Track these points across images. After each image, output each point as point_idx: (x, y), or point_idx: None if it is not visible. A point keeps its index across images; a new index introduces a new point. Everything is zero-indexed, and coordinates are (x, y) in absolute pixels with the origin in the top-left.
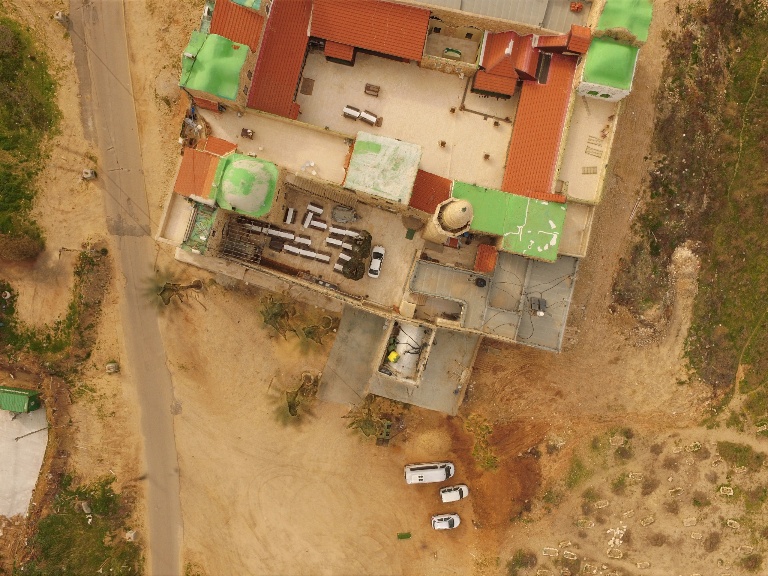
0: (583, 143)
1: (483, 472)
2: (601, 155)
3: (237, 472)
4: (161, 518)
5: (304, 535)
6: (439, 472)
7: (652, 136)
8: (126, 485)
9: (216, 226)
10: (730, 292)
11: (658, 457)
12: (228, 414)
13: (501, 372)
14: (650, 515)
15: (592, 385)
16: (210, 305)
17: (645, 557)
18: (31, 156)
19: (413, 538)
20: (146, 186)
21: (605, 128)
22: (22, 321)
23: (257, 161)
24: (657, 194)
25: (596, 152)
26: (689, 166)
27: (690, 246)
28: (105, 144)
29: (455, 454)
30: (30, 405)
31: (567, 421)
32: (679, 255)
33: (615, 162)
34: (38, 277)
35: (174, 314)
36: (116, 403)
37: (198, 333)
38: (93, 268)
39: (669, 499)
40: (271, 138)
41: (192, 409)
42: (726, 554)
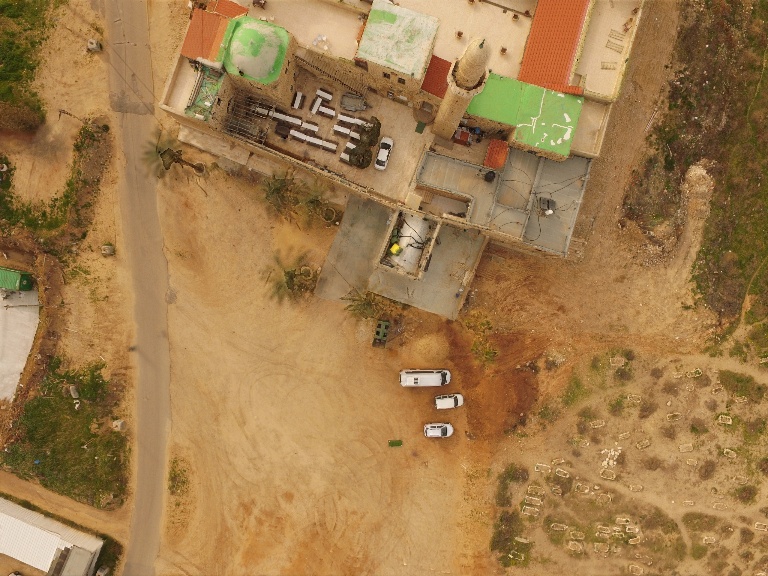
0: (604, 37)
1: (480, 381)
2: (622, 50)
3: (229, 367)
4: (150, 410)
5: (294, 436)
6: (435, 376)
7: (674, 44)
8: (116, 372)
9: (222, 94)
10: (742, 218)
11: (658, 381)
12: (223, 307)
13: (504, 282)
14: (646, 438)
15: (596, 302)
16: (211, 191)
17: (638, 480)
18: (35, 25)
19: (404, 446)
20: (152, 62)
21: (628, 21)
22: (18, 196)
23: (268, 25)
24: (675, 105)
25: (617, 47)
26: (710, 78)
27: (705, 165)
28: (112, 16)
29: (452, 362)
30: (22, 283)
31: (568, 338)
32: (693, 173)
33: (635, 69)
34: (37, 151)
35: (174, 198)
36: (110, 287)
37: (197, 220)
38: (93, 143)
39: (666, 424)
40: (283, 9)
41: (187, 299)
42: (720, 483)
